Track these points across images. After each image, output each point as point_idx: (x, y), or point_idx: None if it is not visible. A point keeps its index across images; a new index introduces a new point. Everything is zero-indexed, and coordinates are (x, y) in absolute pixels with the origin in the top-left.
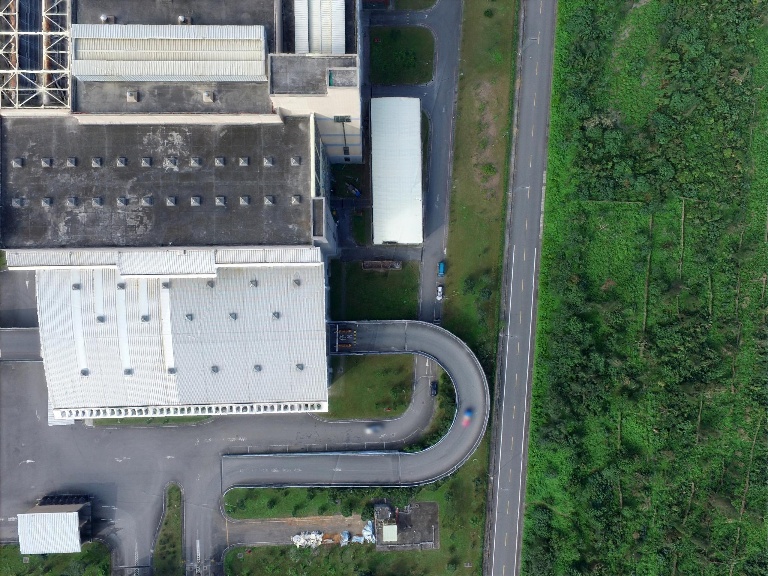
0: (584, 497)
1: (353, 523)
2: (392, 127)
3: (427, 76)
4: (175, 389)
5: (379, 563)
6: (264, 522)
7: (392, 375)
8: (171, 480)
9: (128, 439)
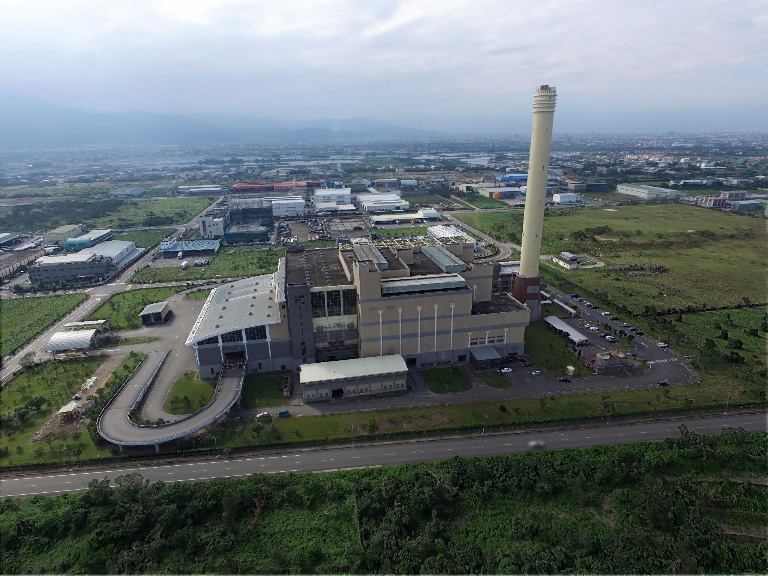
0: (0, 529)
1: None
2: (383, 361)
3: (437, 391)
4: (217, 304)
5: None
6: None
7: None
8: None
9: None
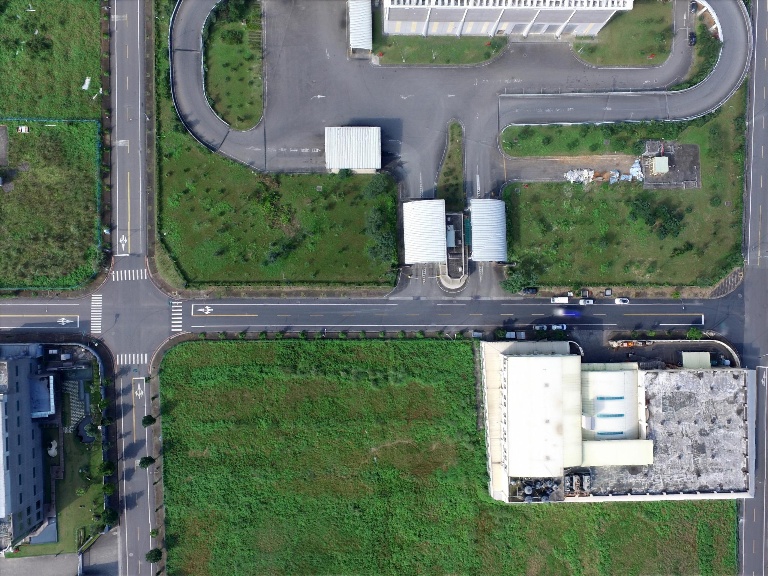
0: None
1: (621, 162)
2: None
3: None
4: None
5: (646, 200)
6: (538, 160)
7: (654, 25)
8: (452, 117)
9: (412, 78)
